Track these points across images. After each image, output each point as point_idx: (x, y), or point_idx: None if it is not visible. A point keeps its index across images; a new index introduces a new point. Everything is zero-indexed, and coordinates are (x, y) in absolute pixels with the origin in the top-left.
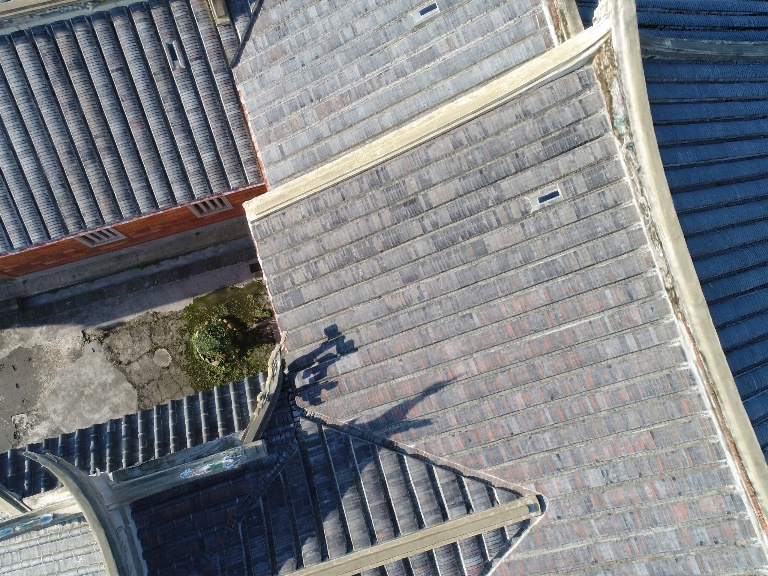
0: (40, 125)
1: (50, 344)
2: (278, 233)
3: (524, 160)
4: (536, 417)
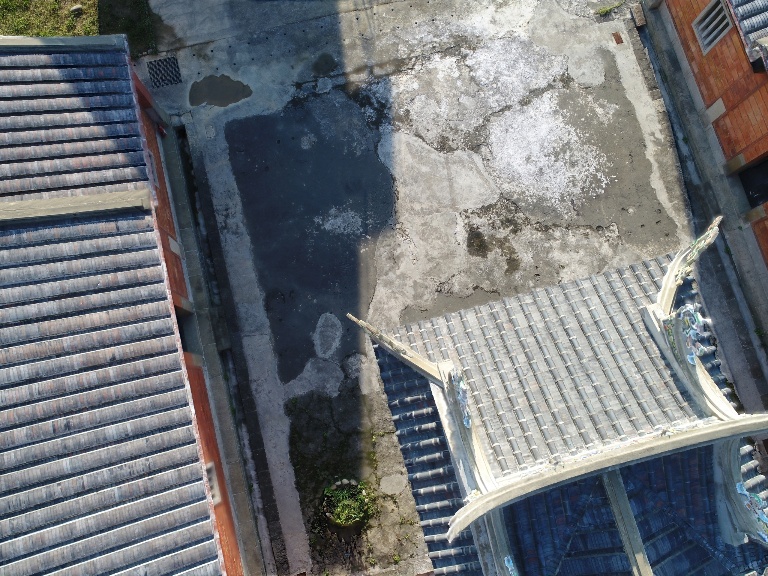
0: None
1: None
2: None
3: None
4: None
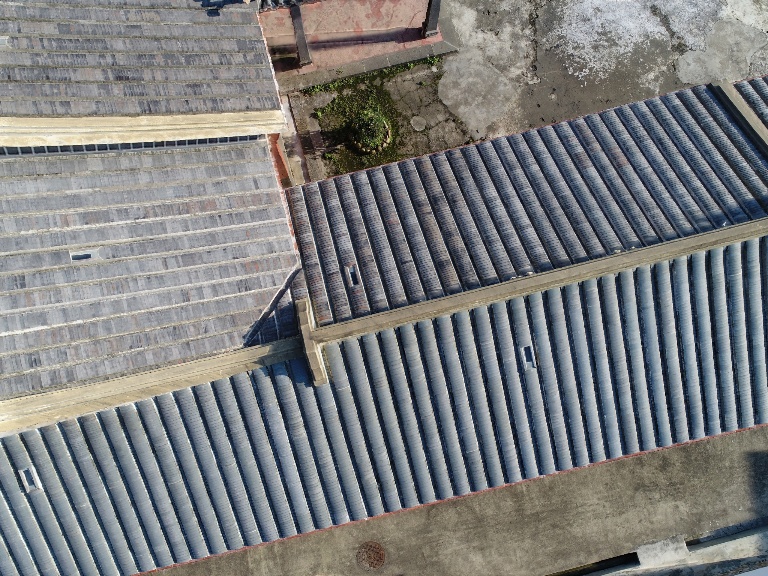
0: (479, 220)
1: None
2: None
3: (3, 72)
4: None
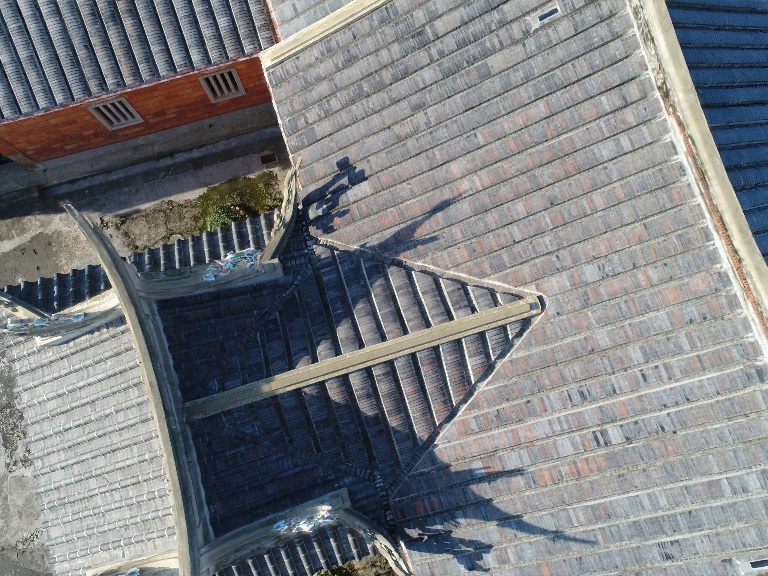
0: None
1: (69, 230)
2: (292, 77)
3: None
4: (537, 223)
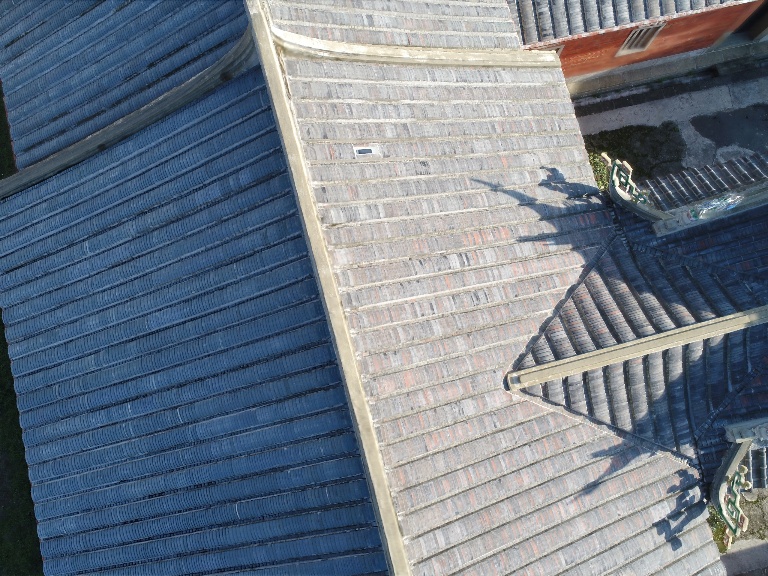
0: None
1: None
2: None
3: None
4: (512, 462)
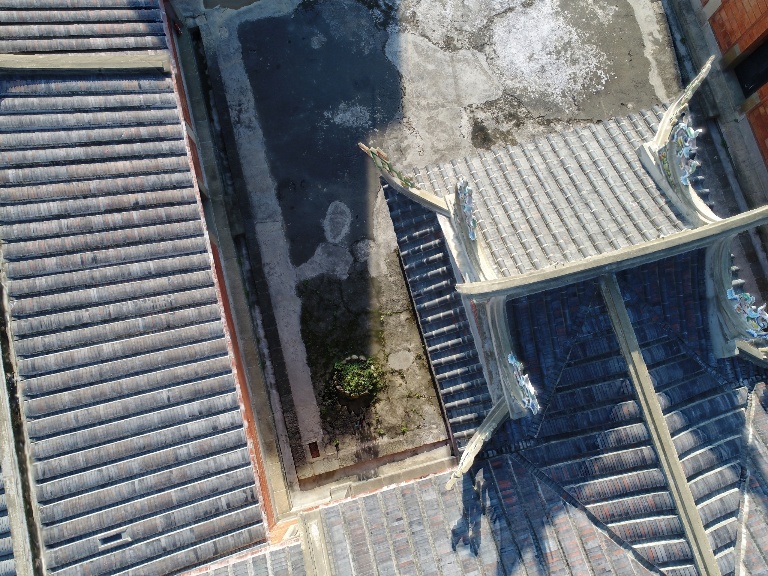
0: None
1: None
2: None
3: None
4: None
